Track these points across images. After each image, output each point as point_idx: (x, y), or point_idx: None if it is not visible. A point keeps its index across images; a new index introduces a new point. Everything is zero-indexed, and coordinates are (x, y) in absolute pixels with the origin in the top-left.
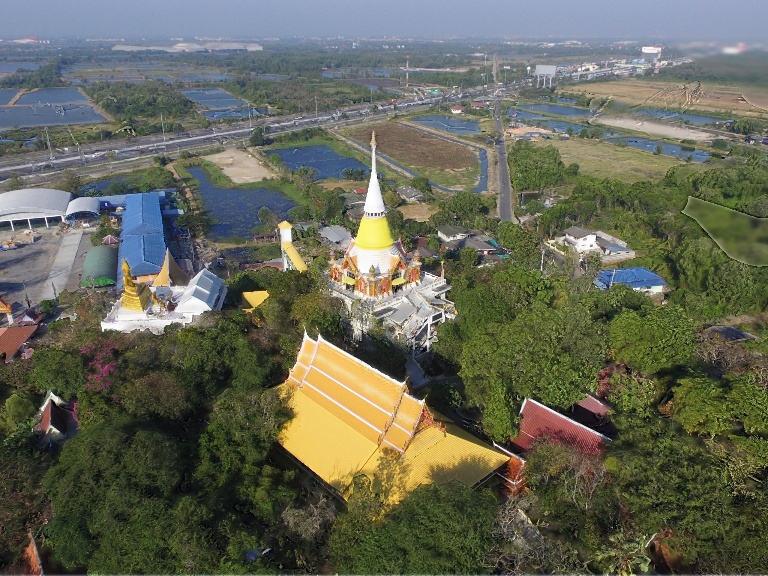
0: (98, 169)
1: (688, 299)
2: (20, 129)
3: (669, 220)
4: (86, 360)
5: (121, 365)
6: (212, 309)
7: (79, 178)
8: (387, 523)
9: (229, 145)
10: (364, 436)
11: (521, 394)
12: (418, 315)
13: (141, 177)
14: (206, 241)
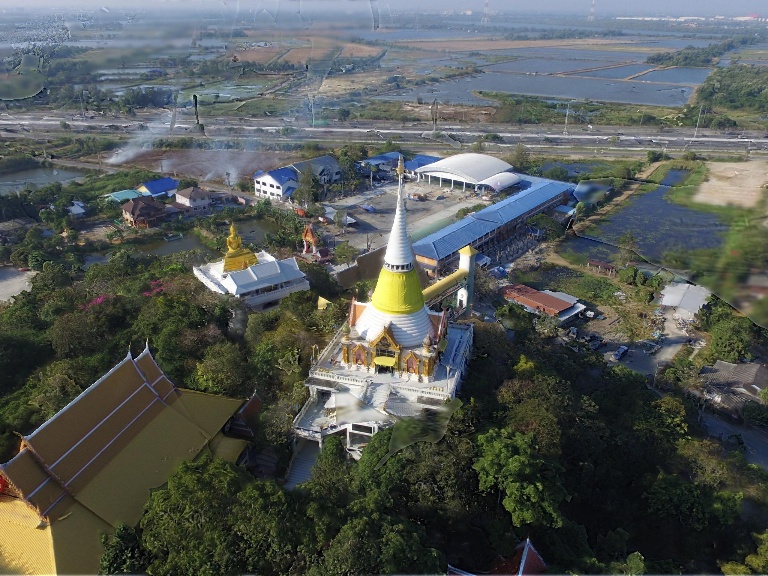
0: (589, 151)
1: None
2: (590, 102)
3: None
4: (148, 289)
5: (112, 300)
6: (236, 294)
7: (529, 154)
8: None
9: (766, 156)
10: None
11: (179, 573)
12: None
13: (611, 168)
14: (549, 248)
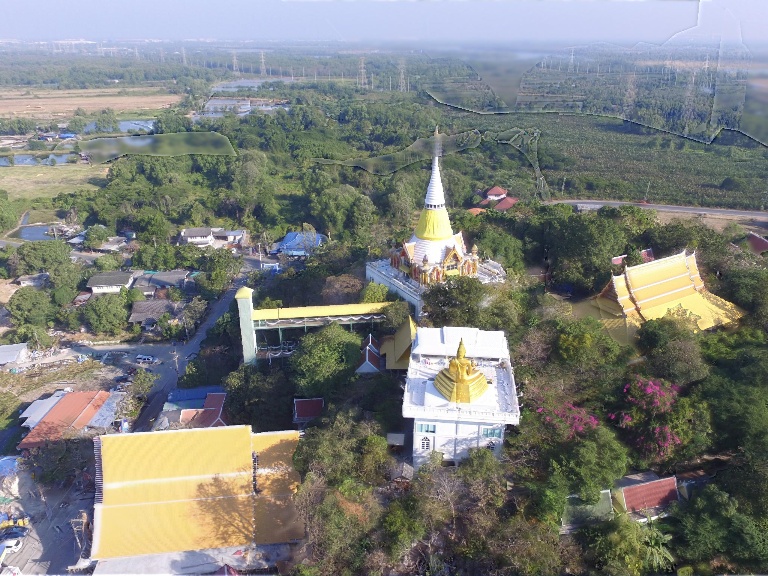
0: None
1: (361, 233)
2: None
3: (233, 198)
4: None
5: None
6: None
7: None
8: None
9: None
10: (690, 295)
11: None
12: None
13: None
14: None
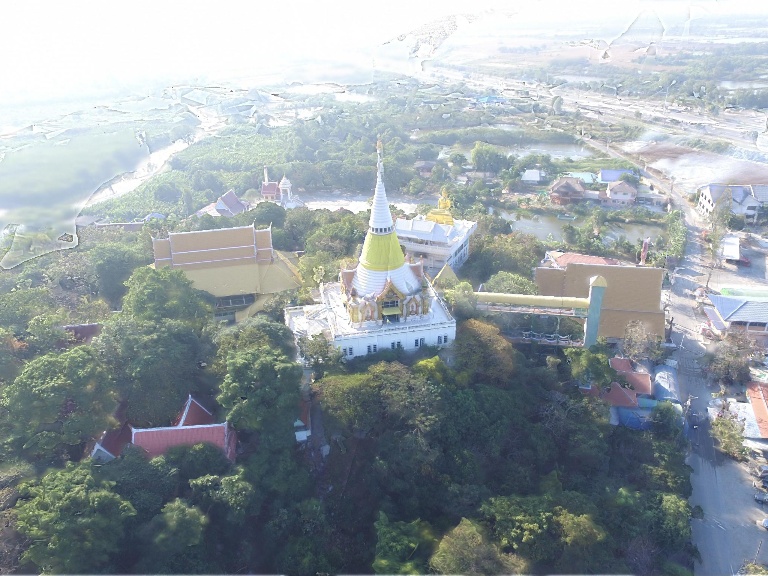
0: None
1: None
2: None
3: None
4: None
5: None
6: None
7: None
8: (137, 250)
9: None
10: None
11: None
12: (305, 318)
13: None
14: None
